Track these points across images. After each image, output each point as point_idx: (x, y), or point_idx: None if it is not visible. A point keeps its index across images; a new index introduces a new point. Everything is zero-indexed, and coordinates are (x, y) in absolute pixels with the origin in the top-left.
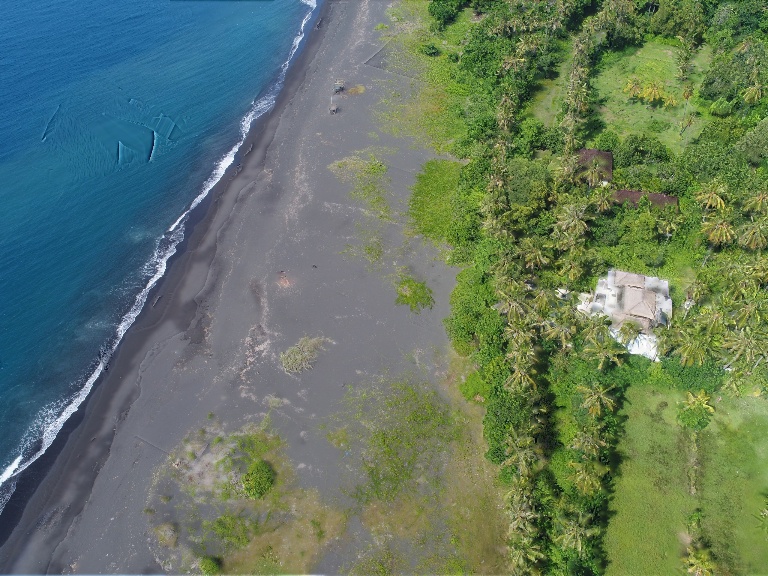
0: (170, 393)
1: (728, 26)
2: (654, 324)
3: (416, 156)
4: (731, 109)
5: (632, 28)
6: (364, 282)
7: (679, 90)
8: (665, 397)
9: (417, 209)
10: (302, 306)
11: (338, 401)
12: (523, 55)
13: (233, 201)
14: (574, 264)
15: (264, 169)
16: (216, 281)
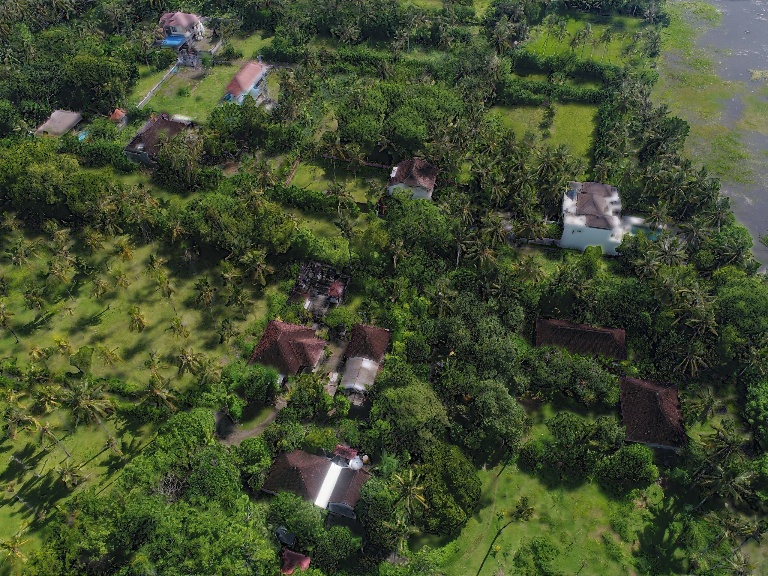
0: None
1: None
2: None
3: None
4: None
5: None
6: None
7: None
8: None
9: None
10: None
11: None
12: None
13: None
14: None
15: None
16: None
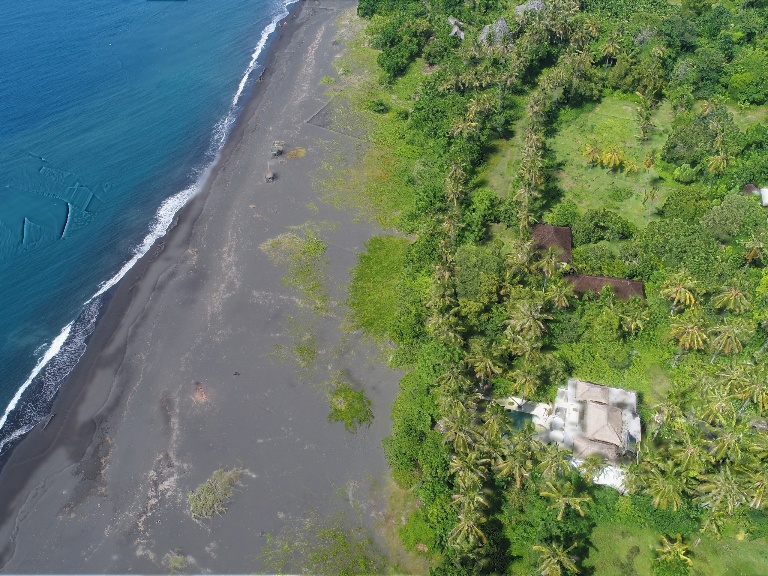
0: (51, 551)
1: (688, 81)
2: (621, 451)
3: (359, 232)
4: (695, 175)
5: (589, 84)
6: (293, 393)
7: (640, 152)
8: (636, 540)
9: (357, 297)
10: (219, 427)
11: (254, 557)
12: (476, 114)
13: (150, 289)
14: (529, 377)
15: (189, 249)
16: (121, 394)
